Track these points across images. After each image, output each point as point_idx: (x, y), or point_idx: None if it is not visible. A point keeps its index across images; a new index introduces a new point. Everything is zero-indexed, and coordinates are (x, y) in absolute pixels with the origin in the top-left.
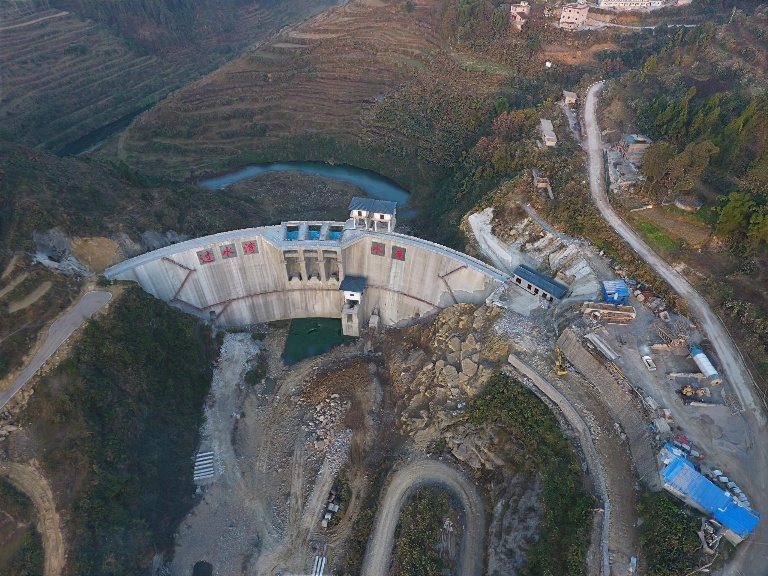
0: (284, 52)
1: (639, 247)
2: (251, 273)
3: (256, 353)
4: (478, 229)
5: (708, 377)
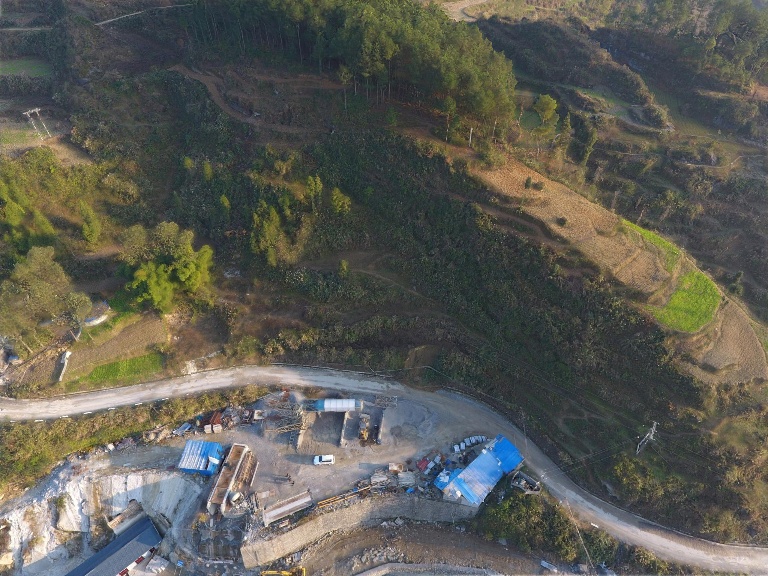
0: None
1: (133, 397)
2: None
3: None
4: None
5: (355, 410)
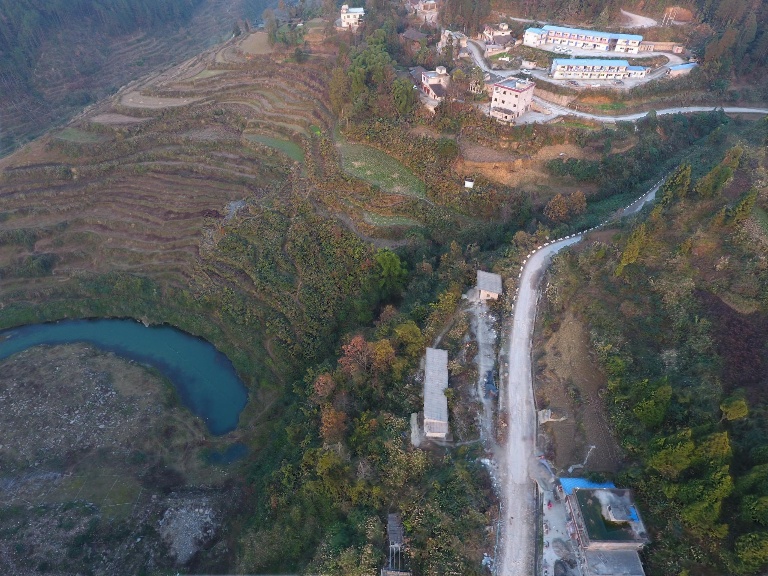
0: (104, 130)
1: None
2: None
3: None
4: None
5: None
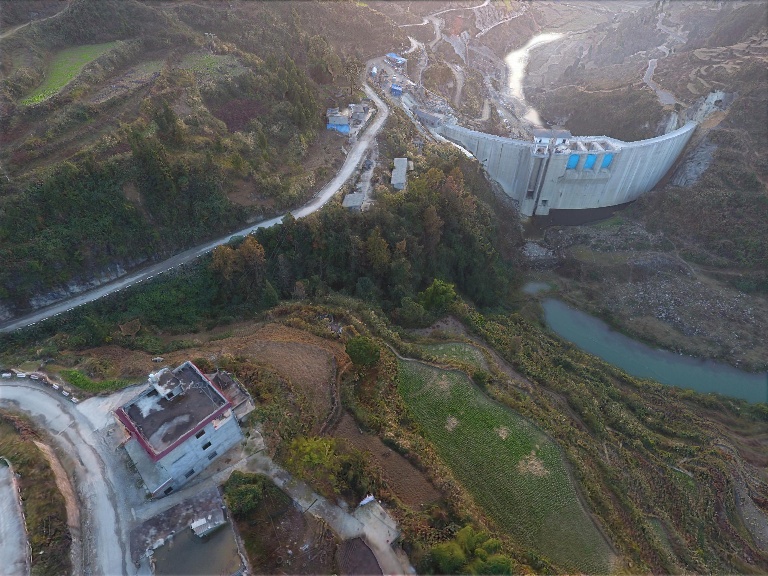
0: None
1: (374, 96)
2: None
3: None
4: (465, 151)
5: None
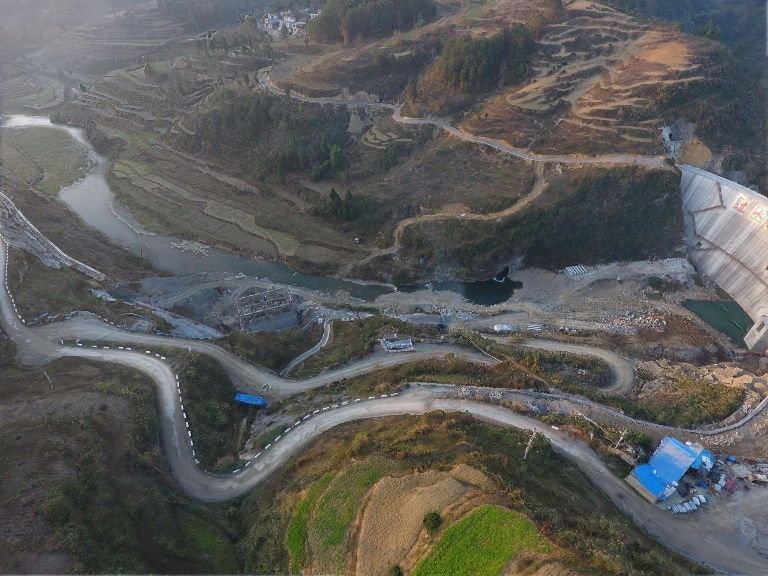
0: None
1: None
2: (754, 243)
3: (679, 280)
4: None
5: None
